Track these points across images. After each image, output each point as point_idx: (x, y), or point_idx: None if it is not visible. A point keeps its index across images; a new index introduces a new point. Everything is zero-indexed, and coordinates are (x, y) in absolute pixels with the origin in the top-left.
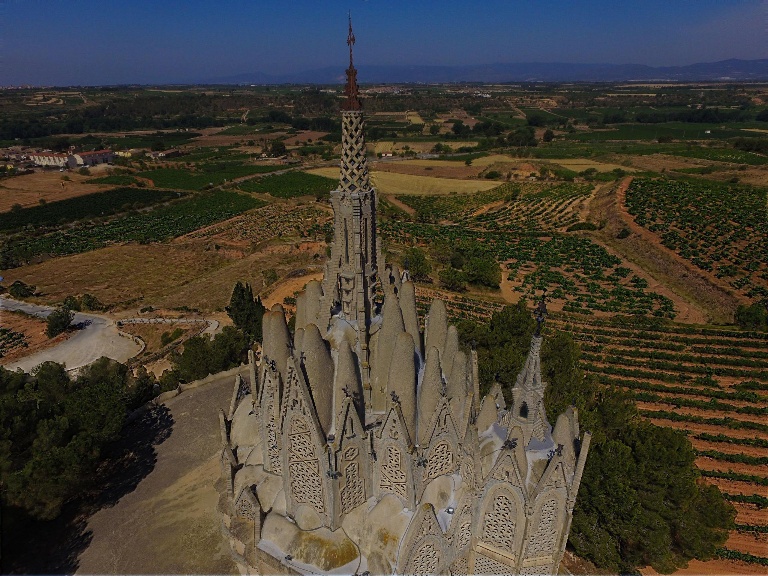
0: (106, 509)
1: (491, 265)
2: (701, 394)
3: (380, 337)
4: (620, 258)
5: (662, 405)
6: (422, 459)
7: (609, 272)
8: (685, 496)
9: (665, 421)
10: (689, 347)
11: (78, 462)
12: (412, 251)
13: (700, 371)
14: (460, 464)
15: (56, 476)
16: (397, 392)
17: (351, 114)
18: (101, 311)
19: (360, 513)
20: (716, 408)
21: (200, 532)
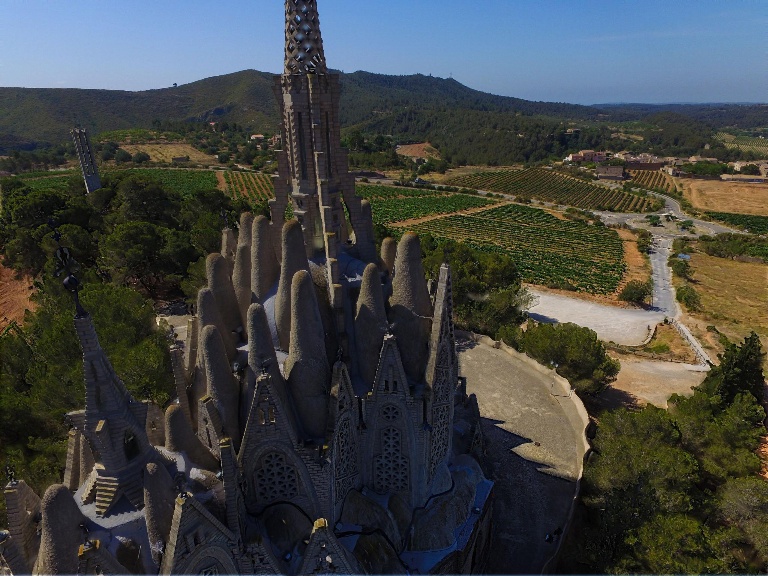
0: None
1: None
2: None
3: None
4: None
5: None
6: None
7: None
8: None
9: None
10: None
11: None
12: None
13: None
14: None
15: None
16: None
17: None
18: (687, 310)
19: None
20: None
21: None
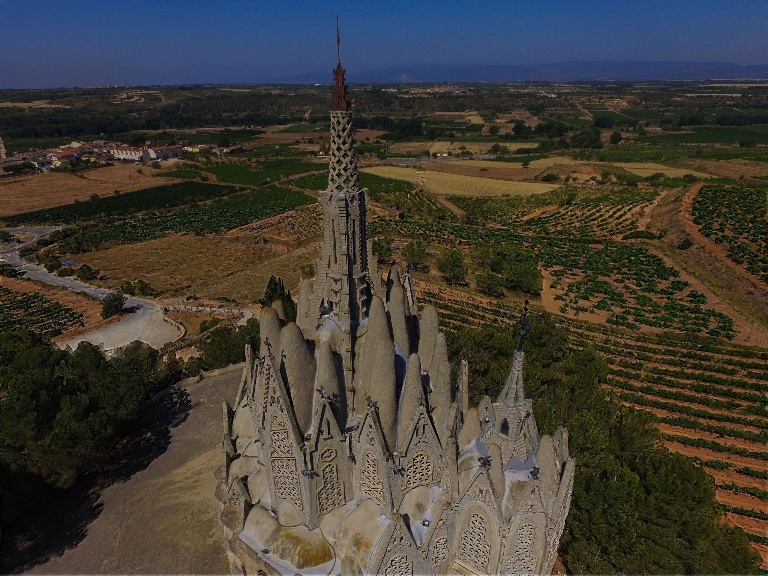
0: (118, 484)
1: (532, 271)
2: (751, 424)
3: (365, 340)
4: (678, 270)
5: (703, 432)
6: (397, 467)
7: (664, 285)
8: (700, 535)
9: (704, 450)
10: (744, 372)
11: (91, 438)
12: (450, 253)
13: (753, 399)
14: (441, 476)
15: (71, 449)
16: (376, 397)
17: (338, 114)
18: (152, 297)
19: (338, 515)
20: (766, 441)
21: (198, 516)
